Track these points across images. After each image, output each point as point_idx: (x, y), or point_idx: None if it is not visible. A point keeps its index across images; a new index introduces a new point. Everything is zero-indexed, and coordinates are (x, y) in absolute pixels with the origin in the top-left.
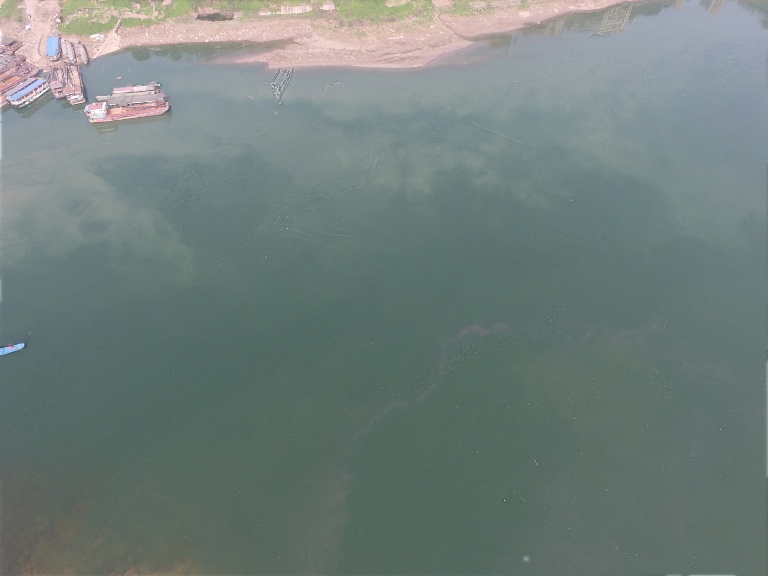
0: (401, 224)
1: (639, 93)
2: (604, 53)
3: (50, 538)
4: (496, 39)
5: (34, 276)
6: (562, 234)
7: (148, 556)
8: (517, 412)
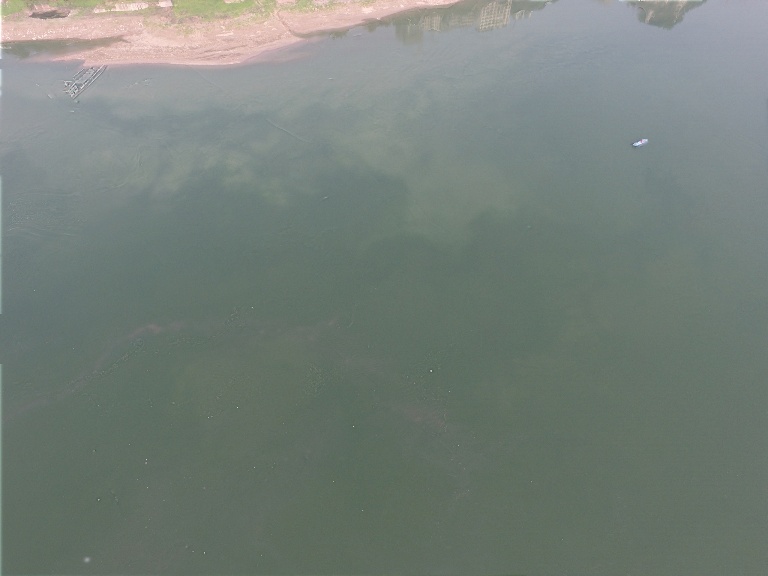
0: (128, 223)
1: (449, 89)
2: (431, 49)
3: None
4: (328, 35)
5: None
6: (291, 232)
7: None
8: (155, 411)
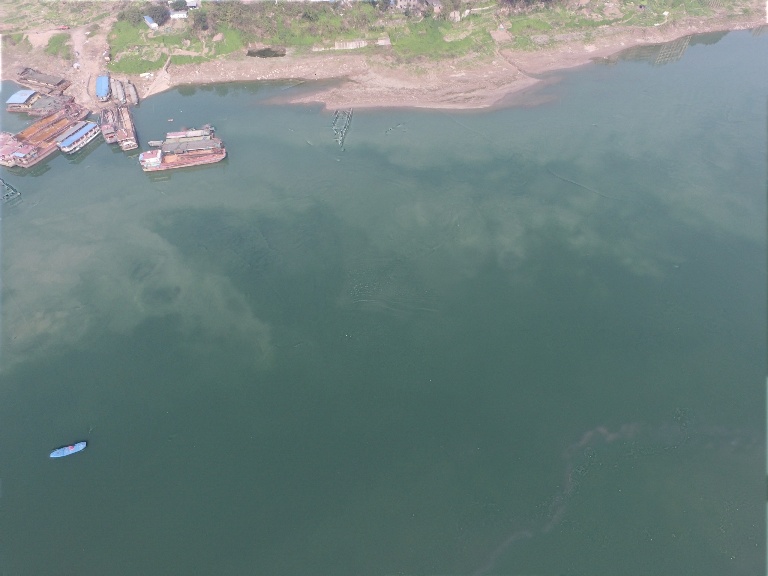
0: (494, 297)
1: (728, 137)
2: (682, 92)
3: None
4: None
5: (93, 356)
6: (676, 311)
7: None
8: (663, 547)
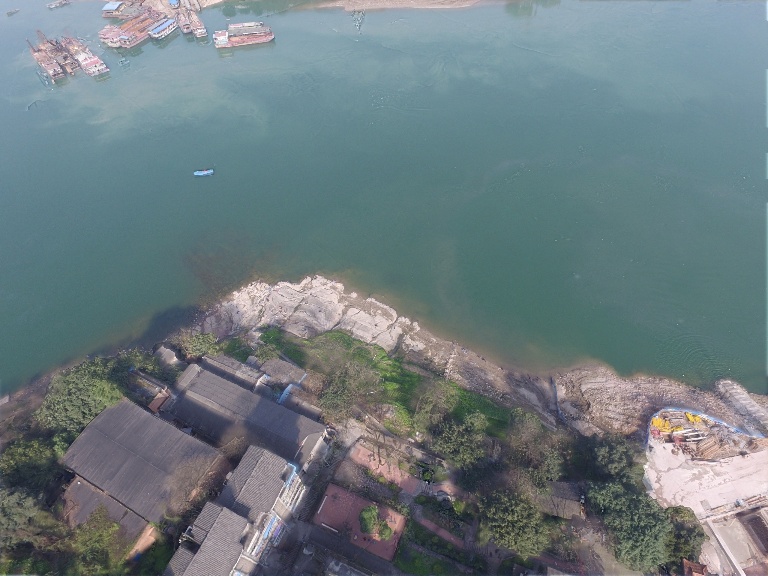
0: (467, 100)
1: (648, 22)
2: None
3: (263, 259)
4: None
5: (207, 135)
6: (589, 106)
7: (327, 266)
8: (561, 199)
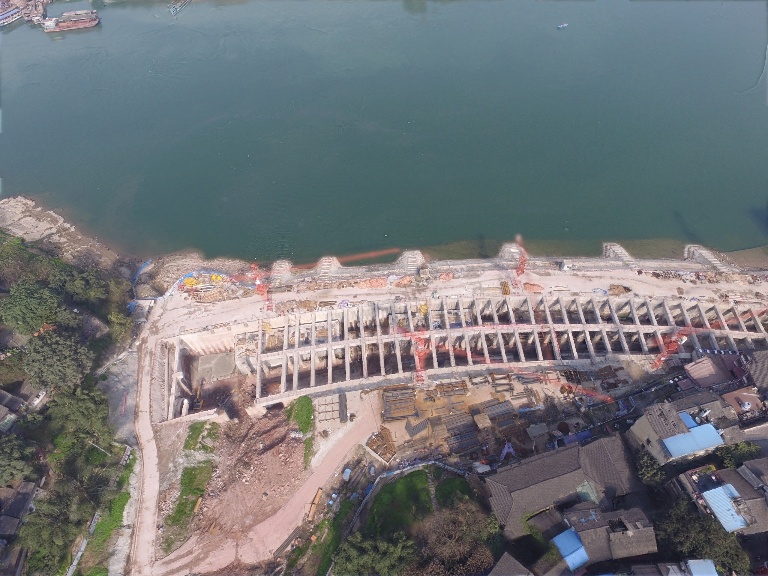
0: (222, 68)
1: (434, 5)
2: None
3: None
4: None
5: None
6: (324, 71)
7: (33, 190)
8: (250, 140)
